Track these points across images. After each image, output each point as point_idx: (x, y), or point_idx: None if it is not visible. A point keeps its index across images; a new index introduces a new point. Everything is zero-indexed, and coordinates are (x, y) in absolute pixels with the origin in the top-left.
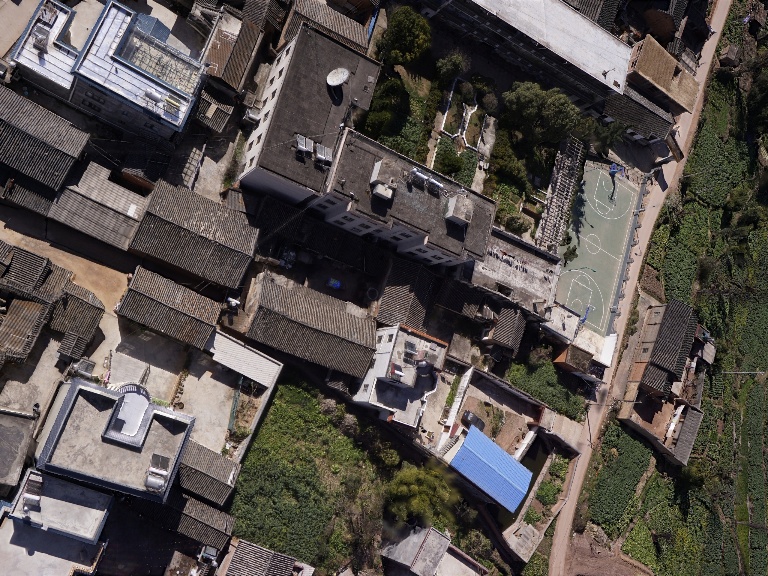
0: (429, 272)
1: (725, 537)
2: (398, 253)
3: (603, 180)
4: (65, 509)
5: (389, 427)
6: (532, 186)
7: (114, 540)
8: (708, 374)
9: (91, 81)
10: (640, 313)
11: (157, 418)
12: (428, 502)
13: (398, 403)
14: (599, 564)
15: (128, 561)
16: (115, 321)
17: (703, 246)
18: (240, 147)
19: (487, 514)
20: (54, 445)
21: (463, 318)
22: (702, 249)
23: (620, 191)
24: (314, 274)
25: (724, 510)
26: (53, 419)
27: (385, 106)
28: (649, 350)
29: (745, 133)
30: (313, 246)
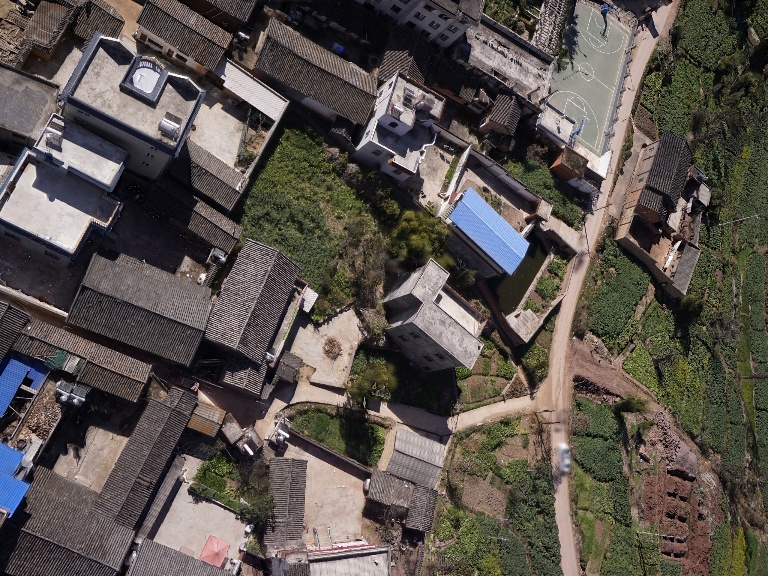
0: (427, 44)
1: (728, 386)
2: None
3: (595, 17)
4: (84, 155)
5: (390, 183)
6: (526, 1)
7: (128, 234)
8: (705, 225)
9: None
10: (635, 148)
11: (171, 82)
12: (427, 237)
13: (398, 150)
14: (600, 373)
15: (141, 255)
16: (133, 45)
17: (696, 101)
18: None
19: (487, 290)
20: (76, 83)
21: (461, 107)
22: (695, 104)
23: (612, 30)
24: (319, 40)
25: (726, 360)
26: None
27: None
28: (644, 179)
29: (734, 10)
30: (318, 8)
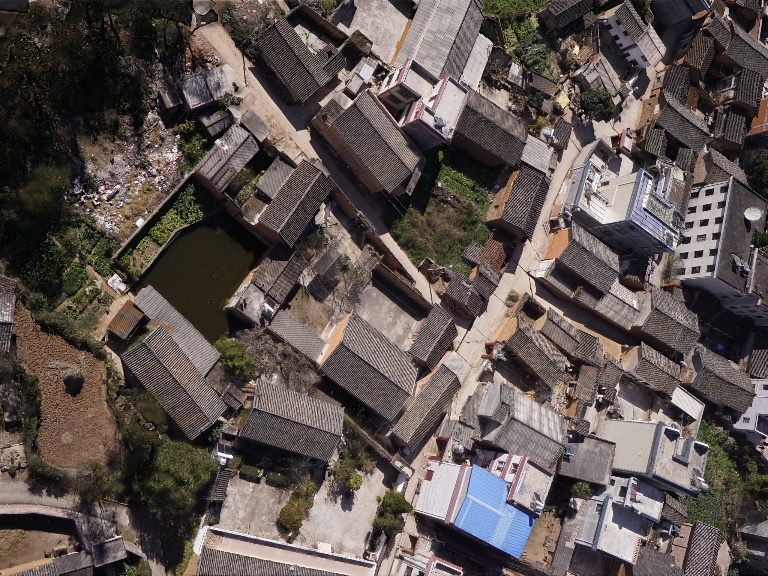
0: None
1: None
2: (755, 326)
3: None
4: (646, 501)
5: None
6: None
7: None
8: None
9: (636, 225)
10: None
11: None
12: None
13: (766, 430)
14: None
15: None
16: None
17: None
18: (670, 254)
19: None
20: None
21: None
22: None
23: None
24: (705, 340)
25: None
26: (624, 444)
27: (766, 229)
28: None
29: None
30: (713, 322)
